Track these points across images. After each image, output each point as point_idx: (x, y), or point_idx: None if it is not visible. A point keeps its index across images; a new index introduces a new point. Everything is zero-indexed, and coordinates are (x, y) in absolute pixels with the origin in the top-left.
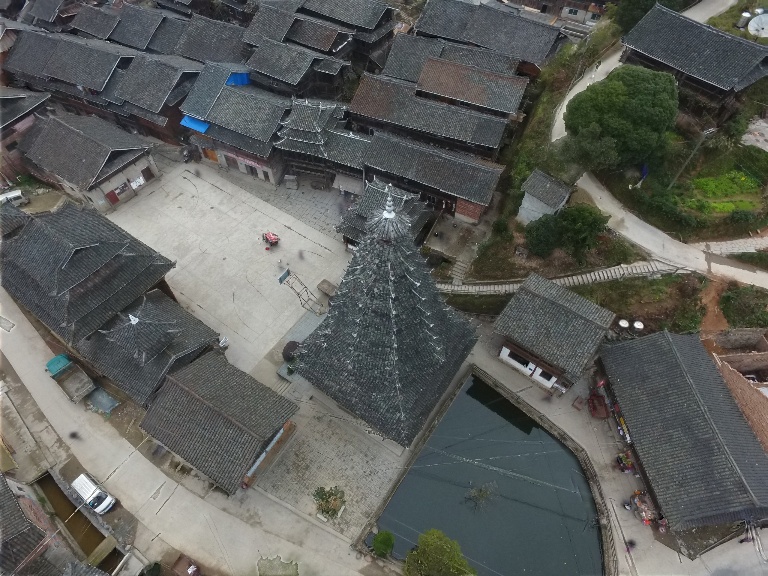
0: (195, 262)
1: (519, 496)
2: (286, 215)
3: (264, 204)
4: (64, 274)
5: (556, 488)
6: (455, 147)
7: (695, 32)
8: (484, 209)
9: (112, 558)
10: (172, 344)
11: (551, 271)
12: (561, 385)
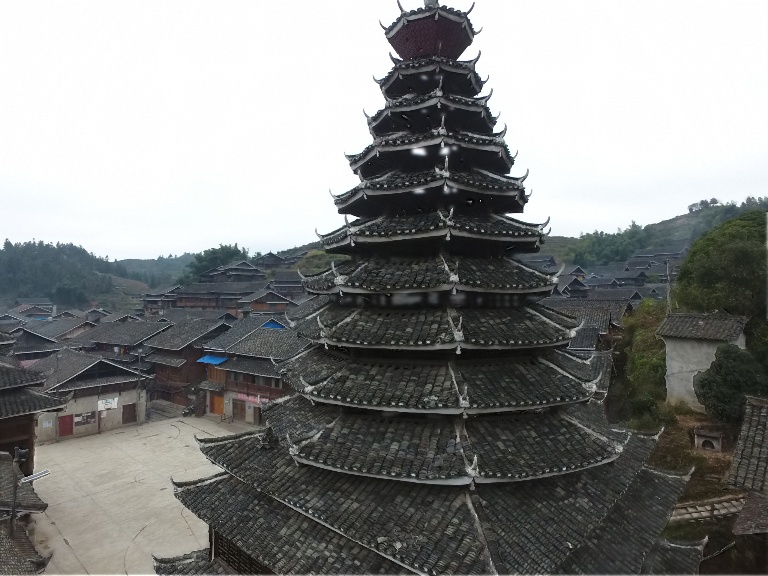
0: (114, 490)
1: None
2: None
3: None
4: None
5: None
6: None
7: None
8: None
9: None
10: None
11: None
12: None
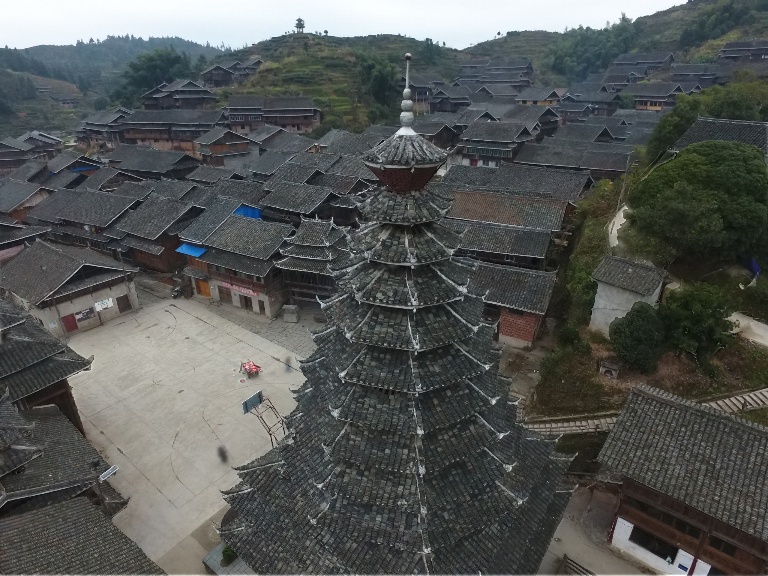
0: (139, 394)
1: None
2: (277, 347)
3: (252, 336)
4: None
5: None
6: None
7: (757, 130)
8: (537, 333)
9: None
10: (19, 476)
11: None
12: None
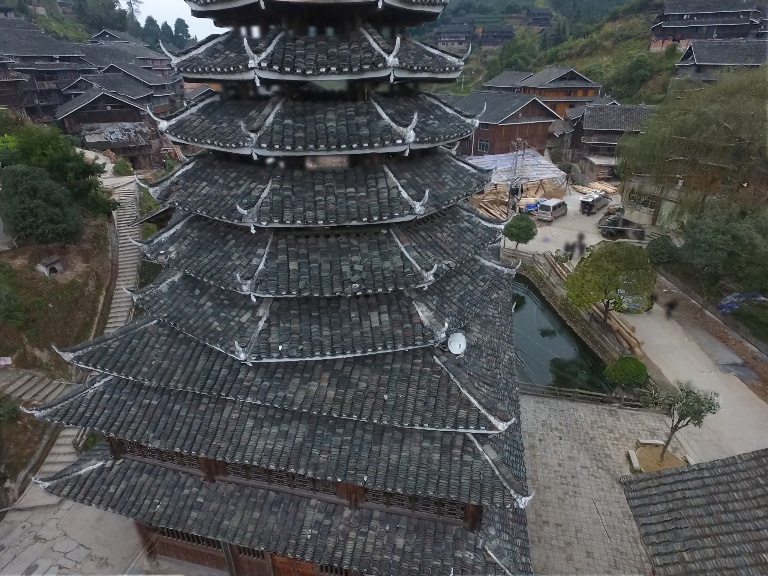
0: None
1: None
2: None
3: None
4: None
5: None
6: None
7: None
8: None
9: None
10: None
11: (99, 261)
12: None
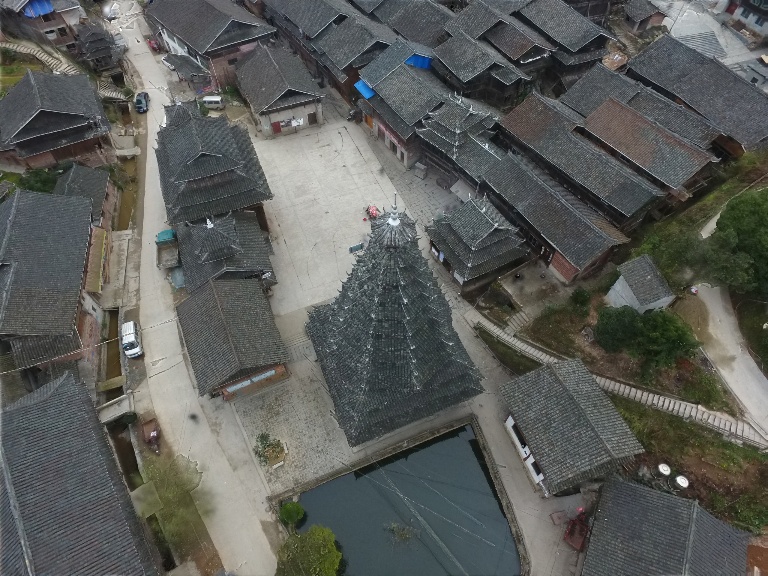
0: (304, 205)
1: (449, 564)
2: (399, 198)
3: (387, 181)
4: (187, 168)
5: (466, 575)
6: (587, 198)
7: None
8: (585, 274)
9: (117, 392)
10: (232, 258)
11: (612, 370)
12: (546, 487)
